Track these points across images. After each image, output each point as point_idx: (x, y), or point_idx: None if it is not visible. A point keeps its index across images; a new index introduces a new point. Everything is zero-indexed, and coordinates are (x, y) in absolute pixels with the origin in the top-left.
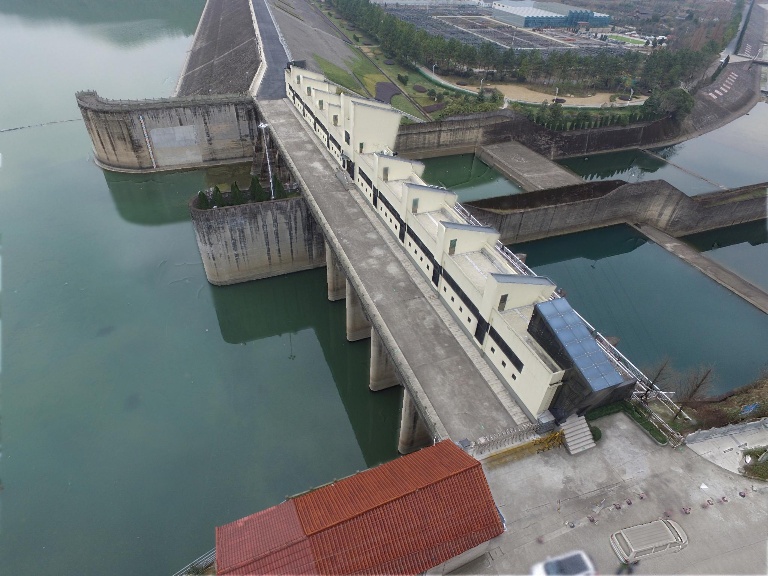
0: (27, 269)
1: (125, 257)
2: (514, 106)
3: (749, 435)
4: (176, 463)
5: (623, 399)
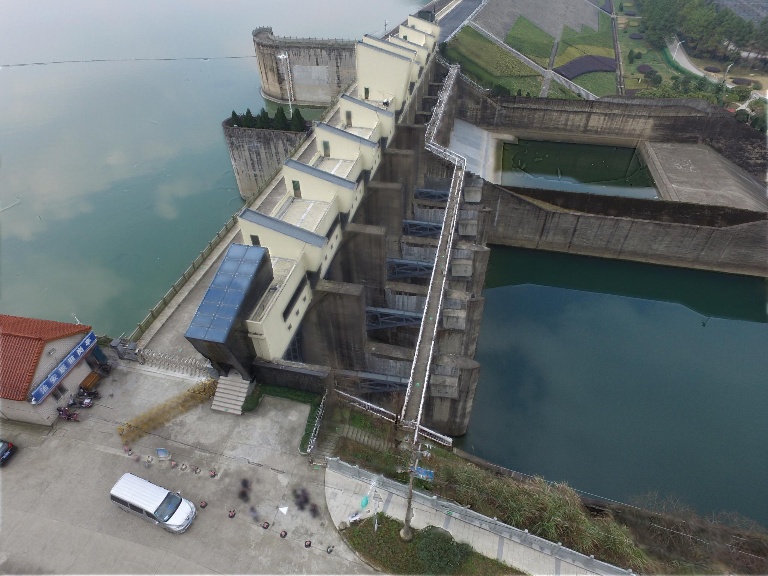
0: (154, 153)
1: (211, 161)
2: (752, 103)
3: (414, 507)
4: (100, 305)
5: (321, 394)
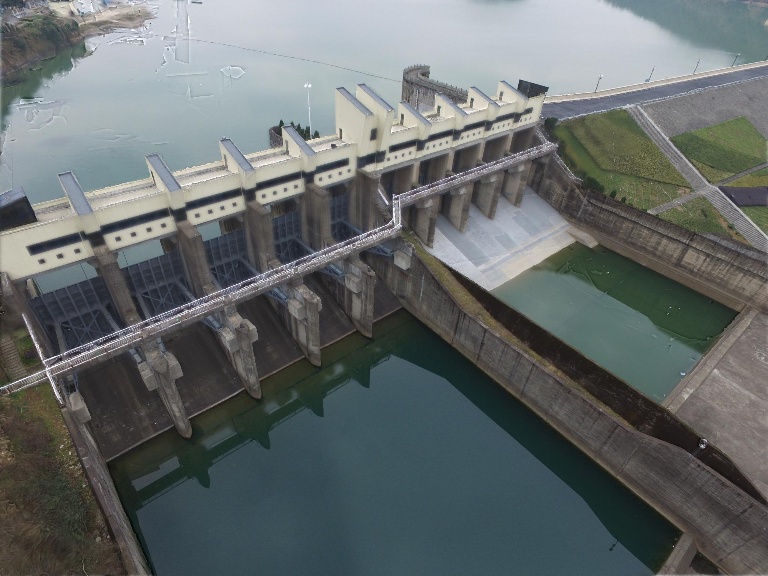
0: None
1: None
2: None
3: None
4: None
5: None
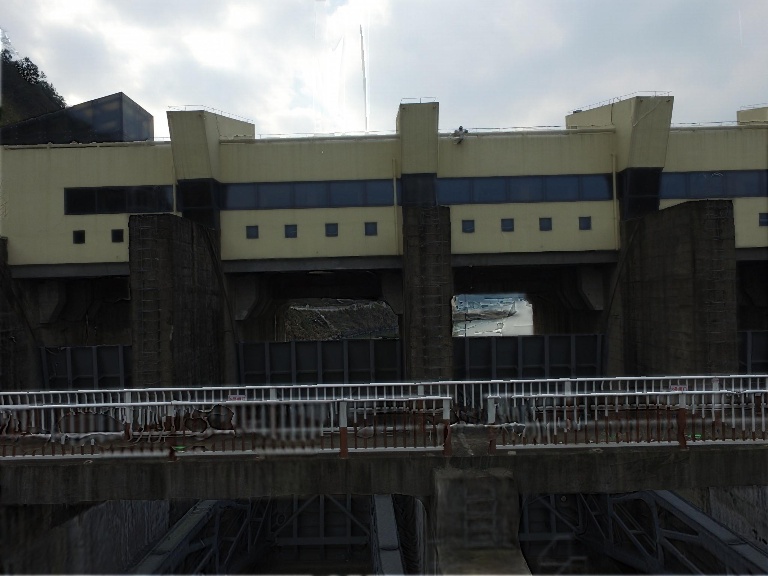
0: None
1: None
2: None
3: None
4: None
5: None
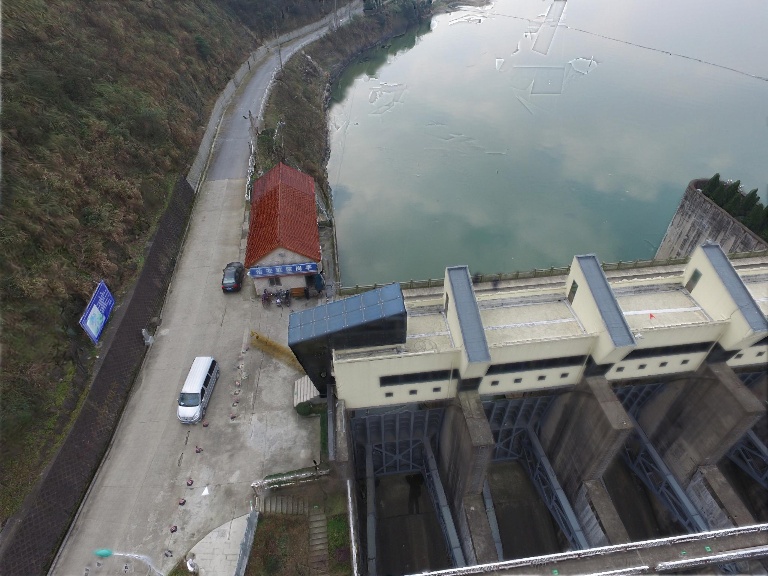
0: (640, 173)
1: None
2: None
3: None
4: (441, 257)
5: None
